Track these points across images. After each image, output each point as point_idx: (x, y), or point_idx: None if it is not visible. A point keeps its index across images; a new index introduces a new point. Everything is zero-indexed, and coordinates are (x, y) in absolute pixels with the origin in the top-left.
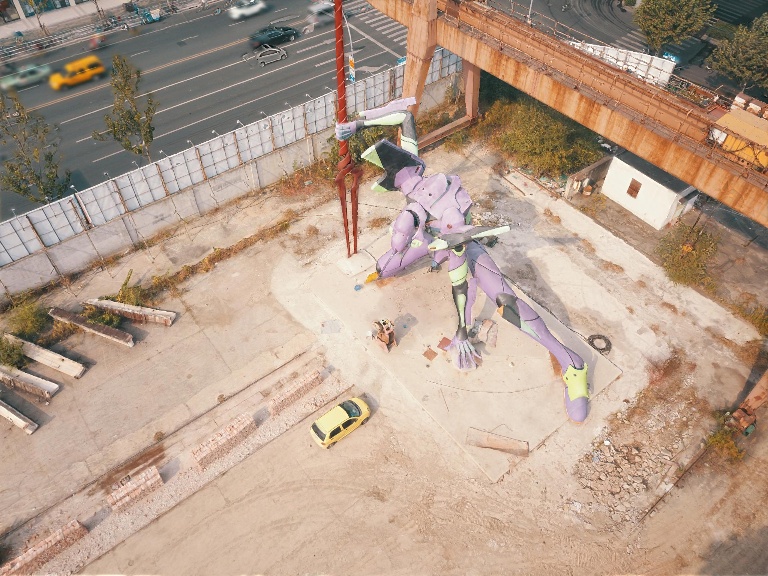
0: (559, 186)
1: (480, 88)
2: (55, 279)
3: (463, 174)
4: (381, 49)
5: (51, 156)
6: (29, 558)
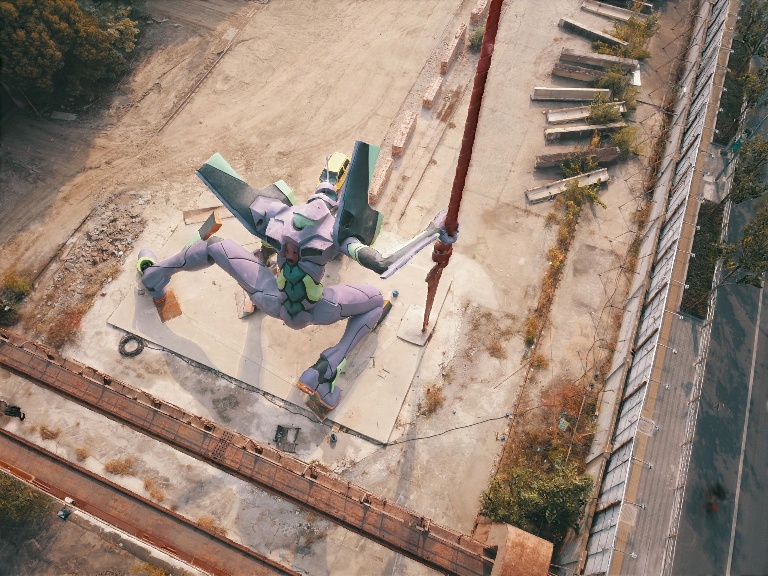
0: None
1: None
2: None
3: (372, 567)
4: None
5: None
6: (452, 43)
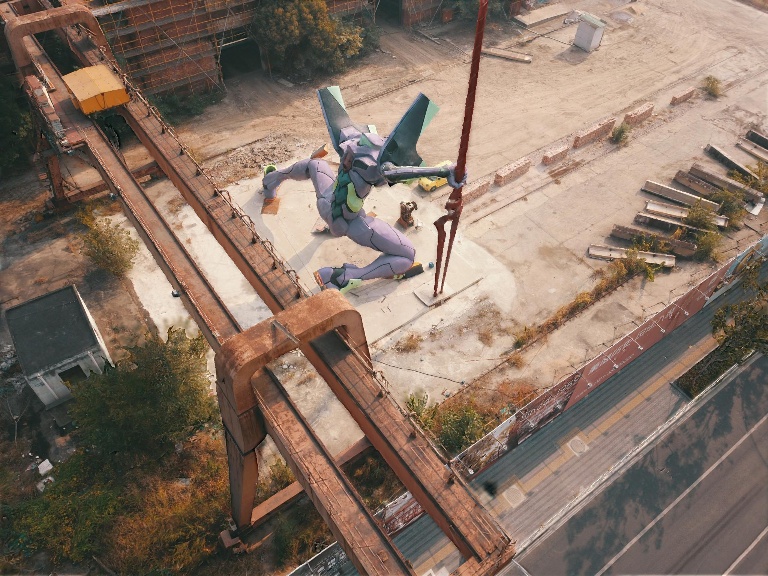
0: None
1: None
2: None
3: None
4: None
5: None
6: (594, 127)
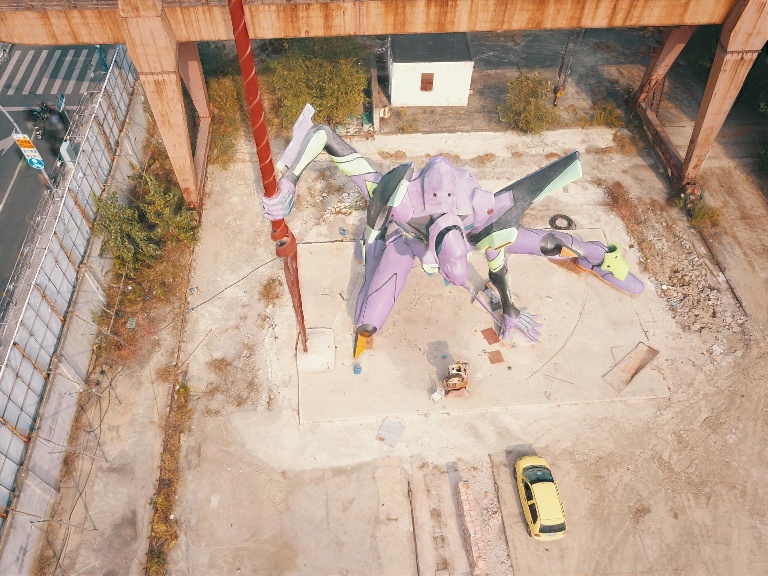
0: (359, 125)
1: None
2: None
3: None
4: None
5: None
6: None
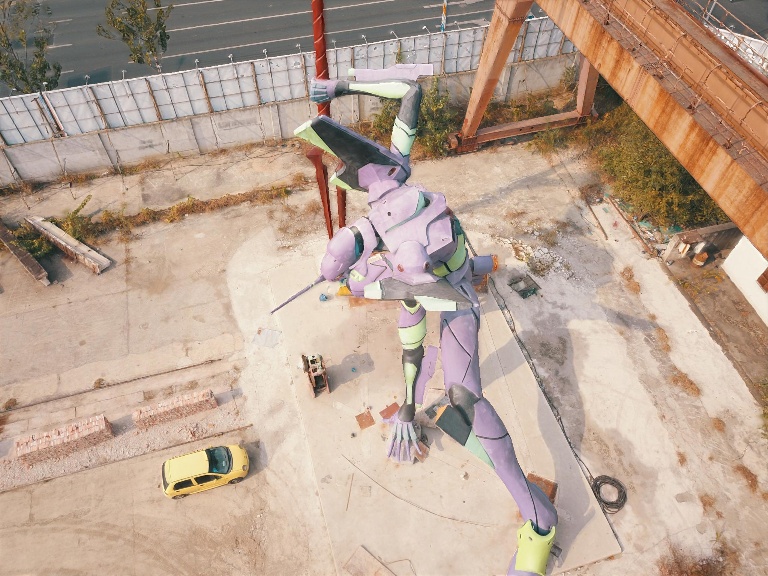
0: (662, 240)
1: None
2: None
3: (537, 187)
4: None
5: (43, 43)
6: None
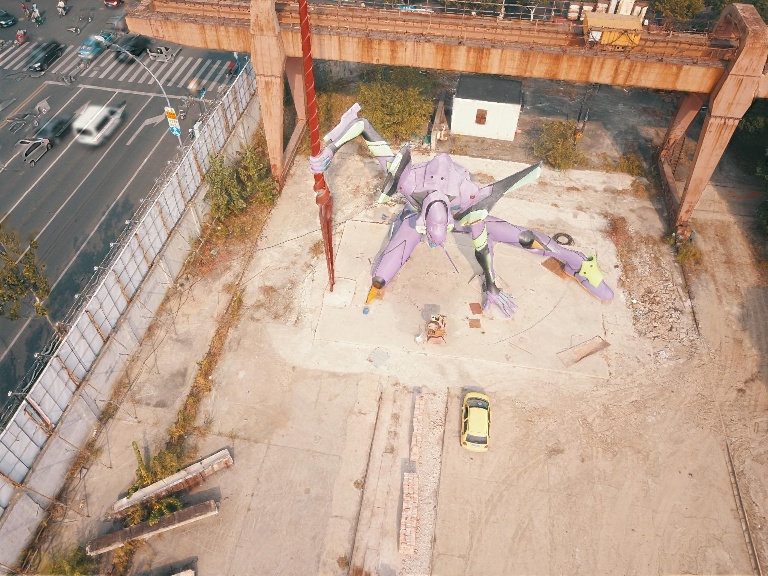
0: (420, 143)
1: (287, 92)
2: (44, 518)
3: (340, 171)
4: (145, 97)
5: None
6: None
